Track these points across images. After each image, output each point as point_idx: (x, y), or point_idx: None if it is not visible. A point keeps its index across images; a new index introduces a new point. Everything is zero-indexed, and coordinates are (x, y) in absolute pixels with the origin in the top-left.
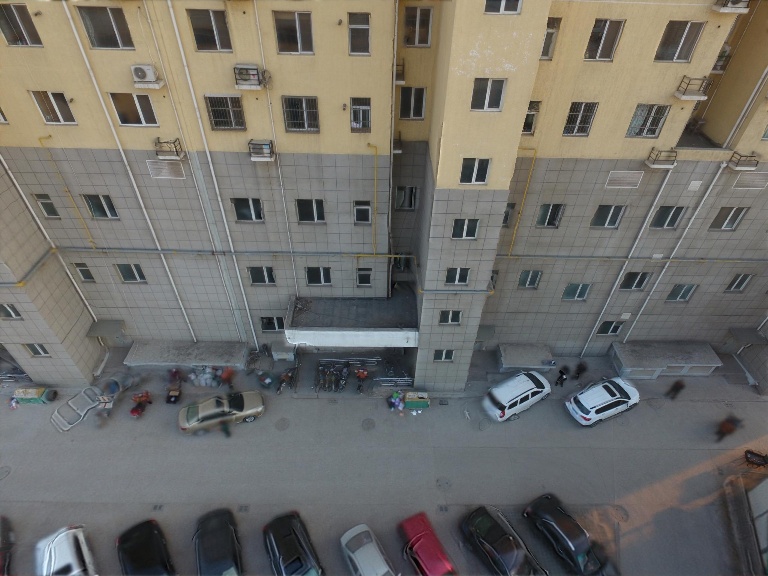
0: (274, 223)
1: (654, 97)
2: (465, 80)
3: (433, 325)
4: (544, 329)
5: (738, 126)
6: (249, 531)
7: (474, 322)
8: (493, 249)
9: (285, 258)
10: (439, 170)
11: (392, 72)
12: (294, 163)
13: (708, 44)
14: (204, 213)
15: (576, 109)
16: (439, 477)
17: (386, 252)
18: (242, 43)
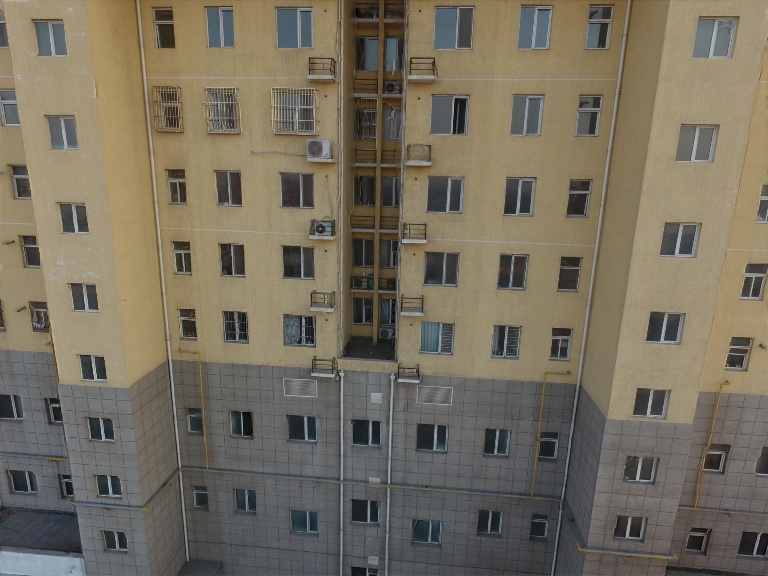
0: None
1: (296, 309)
2: (59, 284)
3: (97, 550)
4: (283, 572)
5: (396, 339)
6: None
7: (142, 550)
8: (134, 454)
9: None
10: (58, 365)
11: None
12: None
13: (323, 265)
14: None
15: (229, 317)
16: None
17: None
18: None
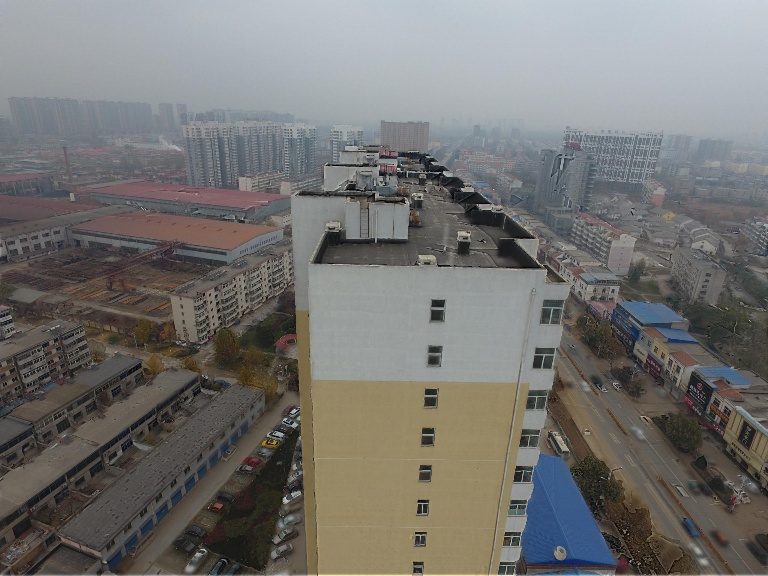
0: None
1: None
2: None
3: None
4: None
5: None
6: (297, 526)
7: None
8: None
9: None
10: None
11: None
12: None
13: None
14: None
15: None
16: (304, 571)
17: None
18: None
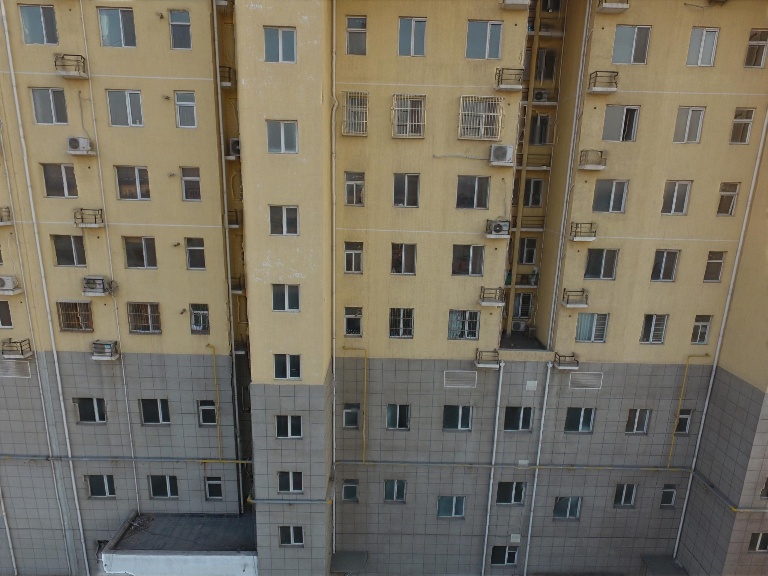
0: (116, 424)
1: (462, 304)
2: (262, 285)
3: (272, 546)
4: (427, 557)
5: (551, 330)
6: None
7: (319, 542)
8: (321, 449)
9: (126, 464)
10: (252, 365)
11: (227, 283)
12: (138, 362)
13: (492, 262)
14: (45, 413)
15: (396, 314)
16: None
17: (234, 457)
18: (95, 260)
